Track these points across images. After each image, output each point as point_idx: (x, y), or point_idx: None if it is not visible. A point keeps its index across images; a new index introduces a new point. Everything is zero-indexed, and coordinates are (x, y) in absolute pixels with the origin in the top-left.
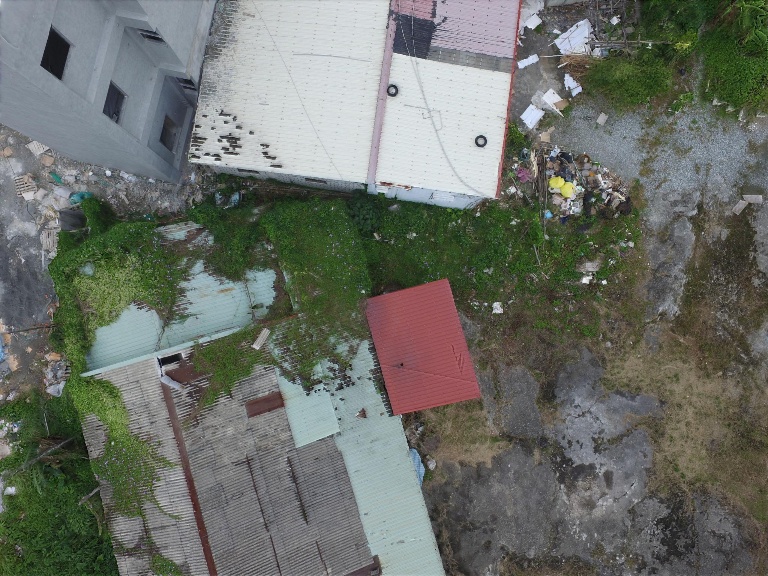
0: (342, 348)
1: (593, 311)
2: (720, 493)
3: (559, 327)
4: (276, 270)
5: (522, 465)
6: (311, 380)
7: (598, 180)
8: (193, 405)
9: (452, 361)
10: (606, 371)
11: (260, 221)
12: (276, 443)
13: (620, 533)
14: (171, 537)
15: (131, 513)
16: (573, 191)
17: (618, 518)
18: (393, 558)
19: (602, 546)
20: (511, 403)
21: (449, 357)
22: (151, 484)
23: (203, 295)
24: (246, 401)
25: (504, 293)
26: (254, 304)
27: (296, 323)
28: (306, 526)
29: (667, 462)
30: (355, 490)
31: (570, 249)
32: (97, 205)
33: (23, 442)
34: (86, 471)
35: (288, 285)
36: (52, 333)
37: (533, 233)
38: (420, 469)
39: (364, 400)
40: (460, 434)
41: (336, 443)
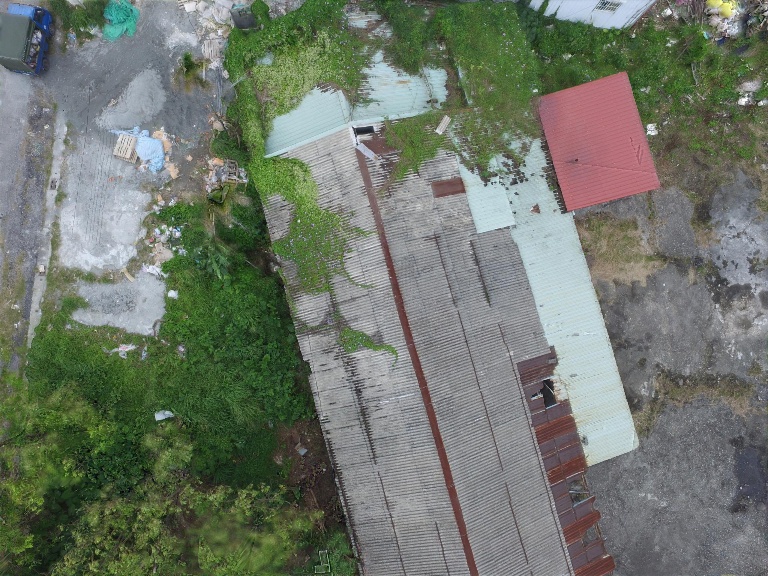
0: (516, 144)
1: (748, 133)
2: None
3: (714, 148)
4: (447, 70)
5: (677, 284)
6: (488, 172)
7: (756, 0)
8: (385, 177)
9: (630, 153)
10: (761, 193)
11: (436, 16)
12: (460, 225)
13: None
14: (362, 308)
15: (318, 289)
16: (730, 12)
17: None
18: (568, 350)
19: (758, 365)
20: (666, 223)
21: (627, 149)
22: (342, 256)
23: (383, 84)
24: (432, 181)
25: (659, 114)
26: (429, 99)
27: (473, 116)
28: (489, 308)
29: None
30: (531, 282)
31: (726, 70)
32: (267, 7)
33: (188, 244)
34: (250, 274)
35: (463, 80)
36: (215, 139)
37: (693, 49)
38: None
39: (538, 196)
40: (615, 253)
41: (512, 235)
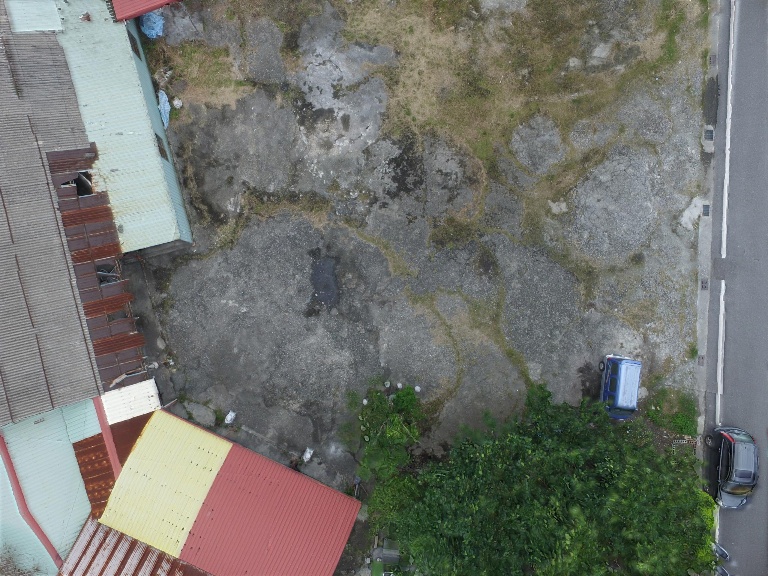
0: None
1: None
2: (448, 136)
3: None
4: None
5: (265, 108)
6: None
7: None
8: None
9: None
10: (346, 23)
11: None
12: None
13: (354, 171)
14: None
15: None
16: None
17: (353, 157)
18: (111, 147)
19: (337, 182)
20: (256, 51)
21: None
22: None
23: None
24: None
25: None
26: None
27: None
28: (18, 100)
29: (400, 107)
30: (75, 83)
31: None
32: None
33: None
34: None
35: None
36: None
37: None
38: (165, 106)
39: (89, 5)
40: (207, 78)
41: (58, 39)
